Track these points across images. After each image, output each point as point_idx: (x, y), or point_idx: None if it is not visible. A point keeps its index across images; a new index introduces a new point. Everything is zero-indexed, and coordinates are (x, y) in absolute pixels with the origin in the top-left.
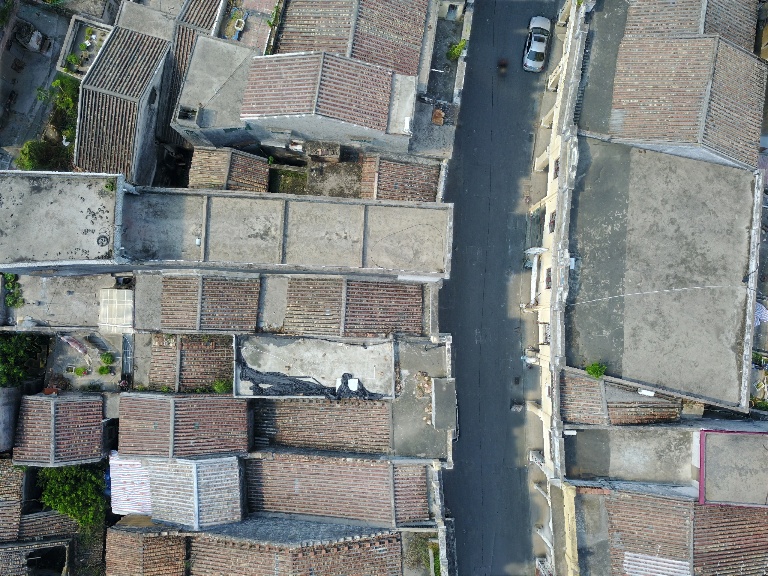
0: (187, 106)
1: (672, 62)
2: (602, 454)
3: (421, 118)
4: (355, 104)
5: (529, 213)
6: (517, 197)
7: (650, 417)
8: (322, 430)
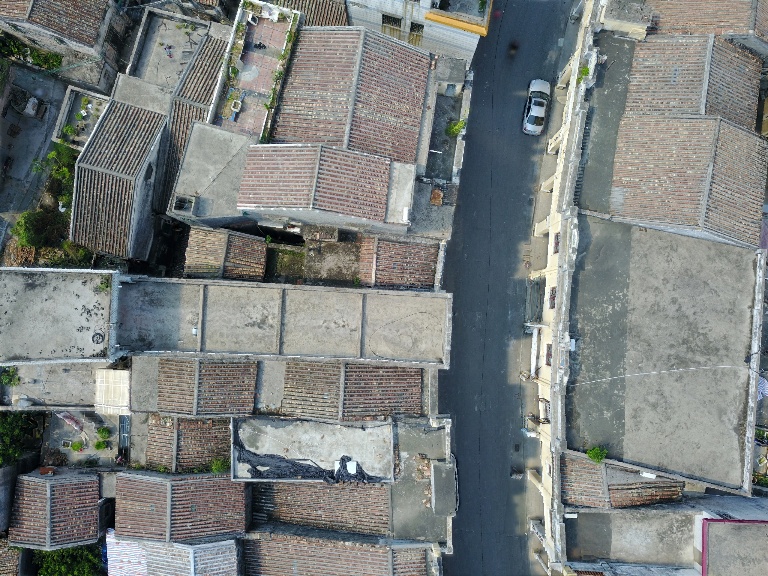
0: (183, 197)
1: (673, 142)
2: (603, 536)
3: (420, 198)
4: (353, 196)
5: (529, 278)
6: (517, 262)
7: (652, 498)
8: (321, 508)
